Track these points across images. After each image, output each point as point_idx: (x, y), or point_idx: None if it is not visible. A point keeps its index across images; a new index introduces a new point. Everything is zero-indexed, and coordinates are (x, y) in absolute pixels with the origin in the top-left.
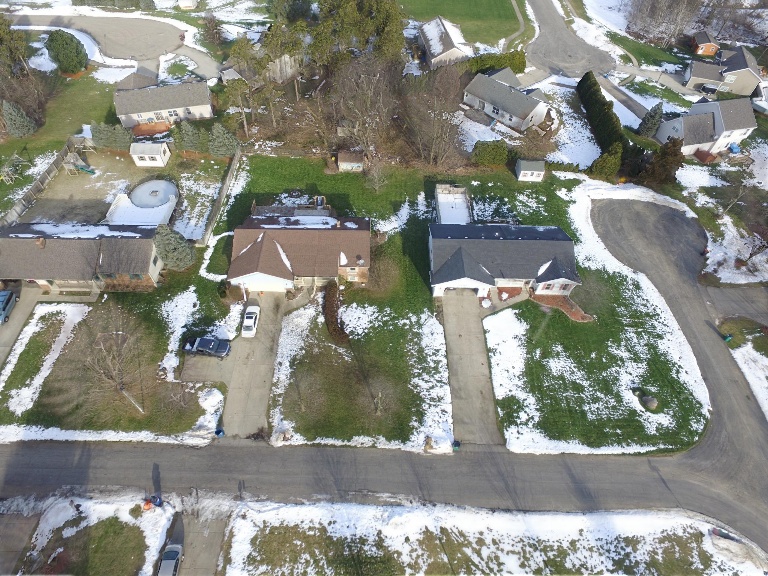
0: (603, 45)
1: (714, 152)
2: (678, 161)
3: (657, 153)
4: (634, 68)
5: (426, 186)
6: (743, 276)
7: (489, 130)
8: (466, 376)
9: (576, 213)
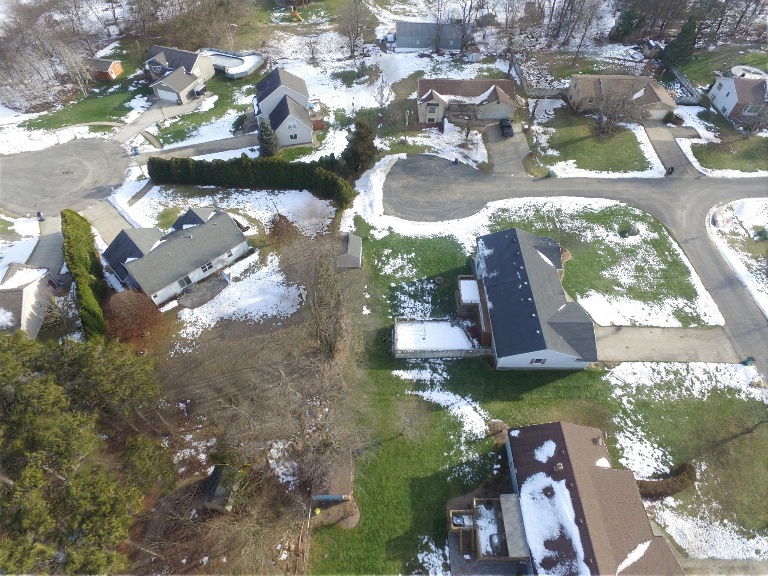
0: (58, 138)
1: None
2: None
3: (356, 144)
4: (126, 128)
5: (380, 367)
6: (480, 149)
7: (239, 284)
8: (671, 347)
9: (408, 230)
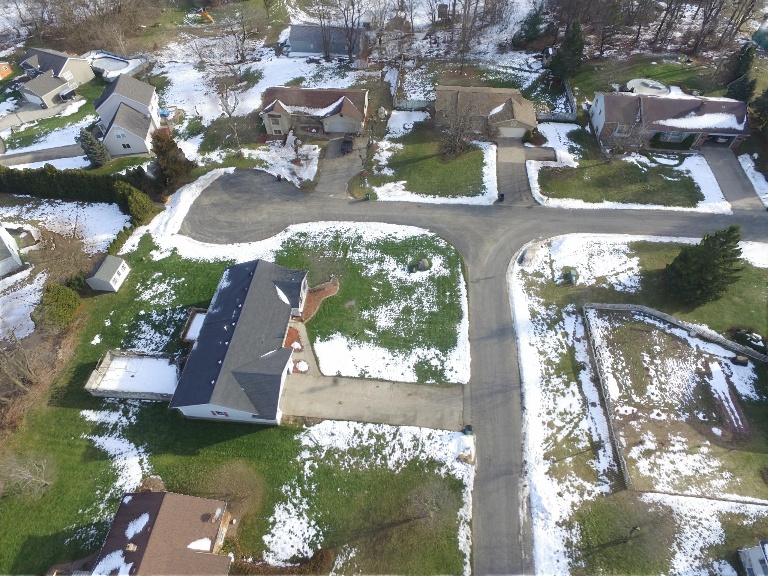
0: None
1: (159, 126)
2: (177, 149)
3: (158, 158)
4: None
5: (72, 405)
6: (310, 166)
7: None
8: (390, 406)
9: (192, 252)
